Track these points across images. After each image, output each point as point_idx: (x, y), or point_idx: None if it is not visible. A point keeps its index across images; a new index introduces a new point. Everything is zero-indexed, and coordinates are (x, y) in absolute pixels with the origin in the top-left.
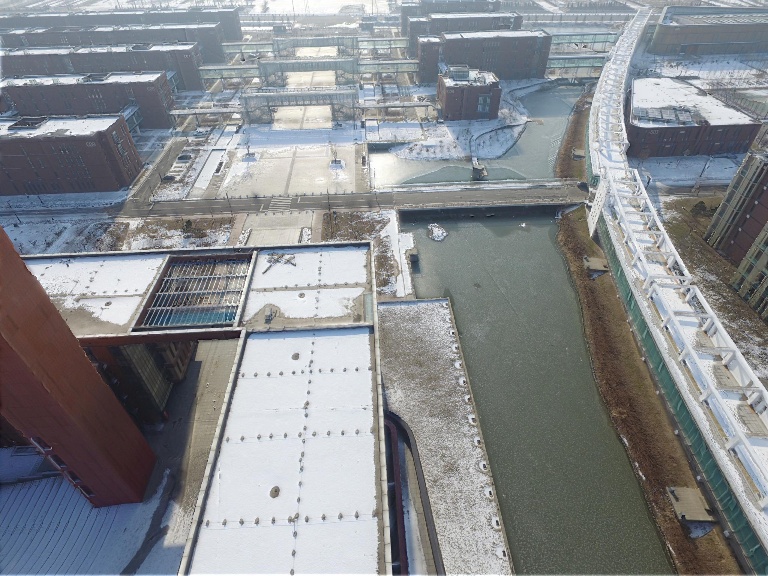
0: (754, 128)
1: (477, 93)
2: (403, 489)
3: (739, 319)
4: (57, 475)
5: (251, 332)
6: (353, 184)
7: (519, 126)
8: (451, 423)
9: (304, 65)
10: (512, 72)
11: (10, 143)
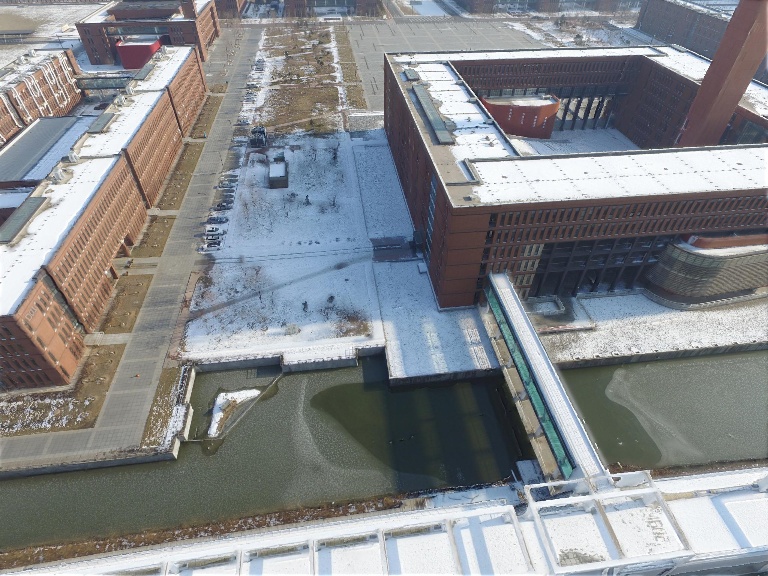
0: None
1: None
2: None
3: None
4: None
5: None
6: None
7: None
8: None
9: None
10: None
11: None
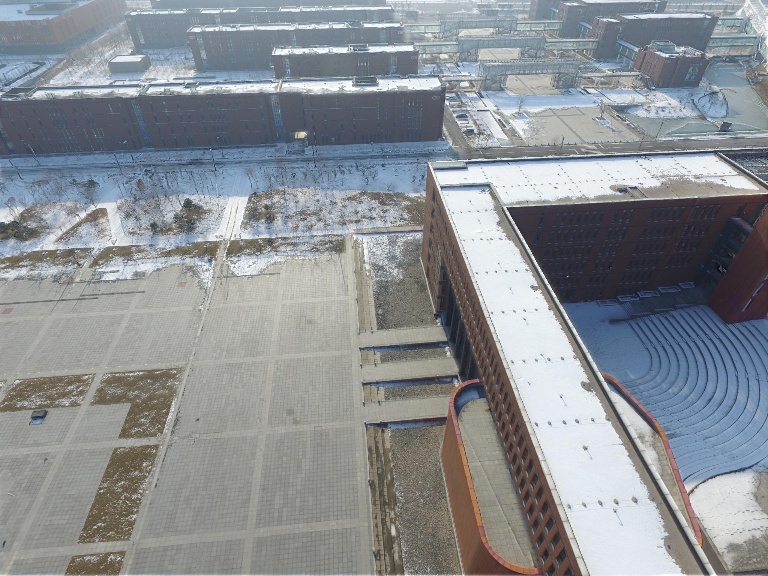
0: None
1: (689, 63)
2: None
3: None
4: (662, 312)
5: None
6: (633, 135)
7: (719, 93)
8: None
9: (499, 42)
10: None
11: (370, 96)
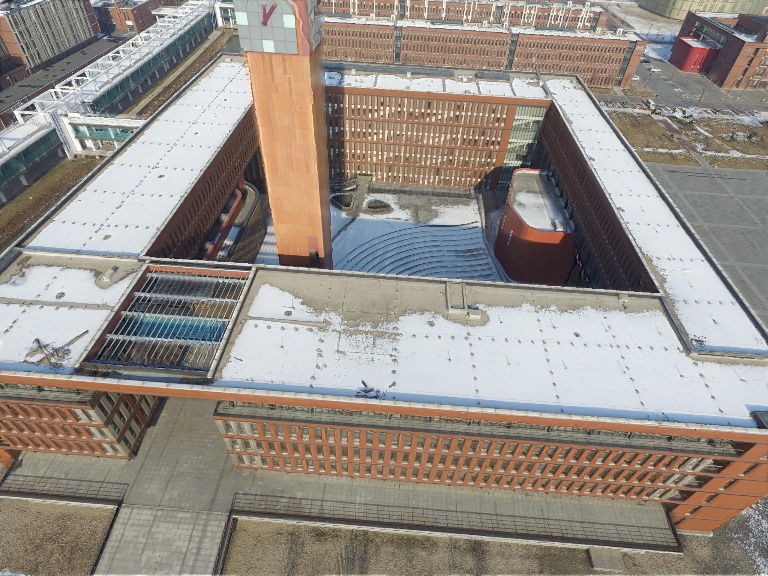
0: None
1: None
2: None
3: None
4: None
5: None
6: None
7: None
8: None
9: None
10: None
11: None
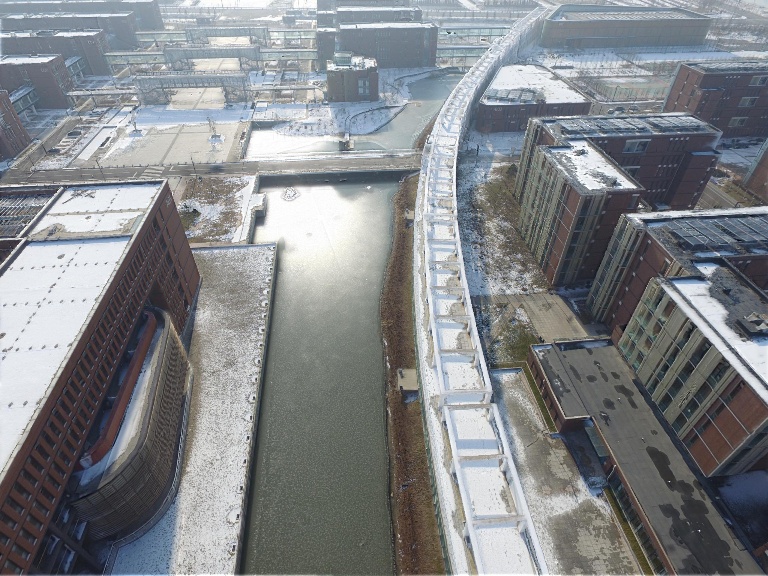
0: (585, 106)
1: (356, 77)
2: (148, 358)
3: (513, 253)
4: None
5: (31, 241)
6: (226, 155)
7: (397, 107)
8: (243, 333)
9: (208, 52)
10: (405, 61)
11: None
